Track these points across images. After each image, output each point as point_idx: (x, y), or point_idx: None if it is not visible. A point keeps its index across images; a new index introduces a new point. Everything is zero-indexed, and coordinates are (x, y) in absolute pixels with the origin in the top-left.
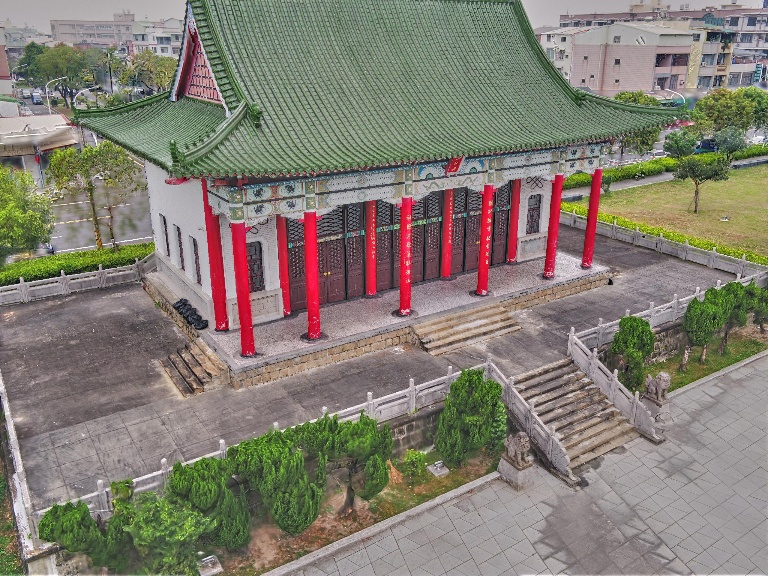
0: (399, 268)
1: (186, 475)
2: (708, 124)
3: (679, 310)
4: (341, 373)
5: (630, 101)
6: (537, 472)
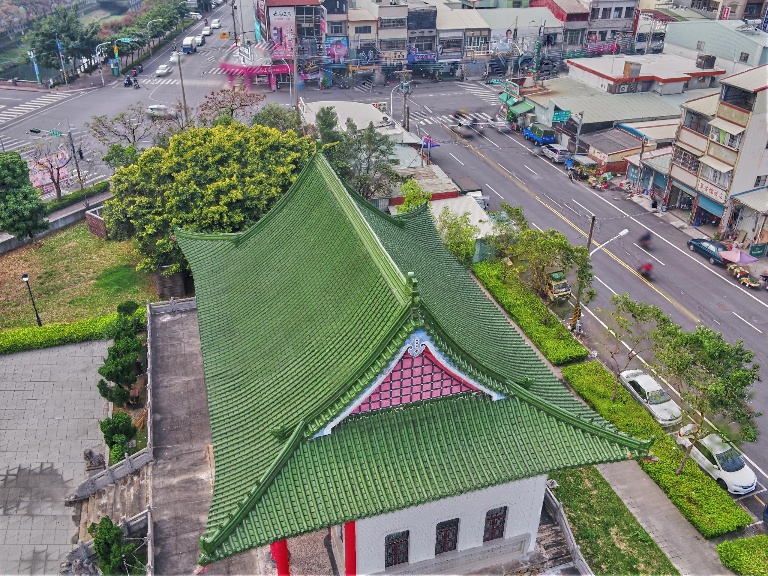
0: None
1: None
2: None
3: None
4: None
5: None
6: None
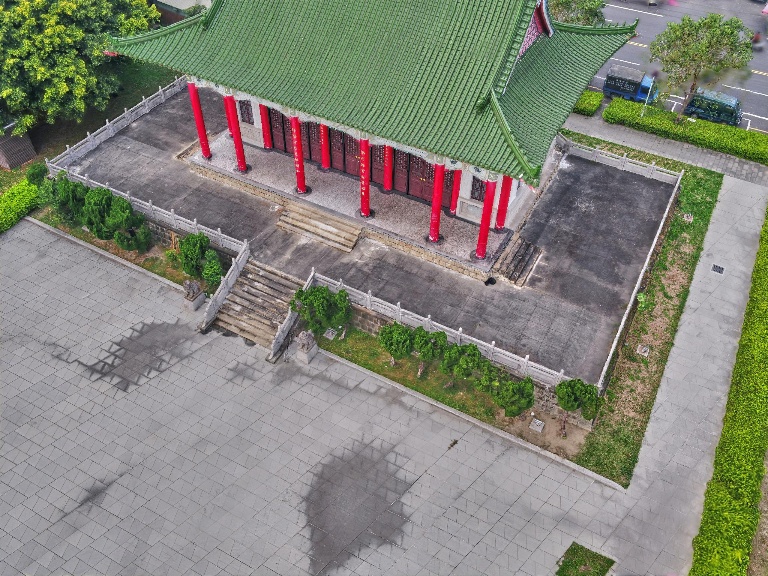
0: (351, 161)
1: None
2: None
3: (433, 330)
4: (230, 197)
5: None
6: None
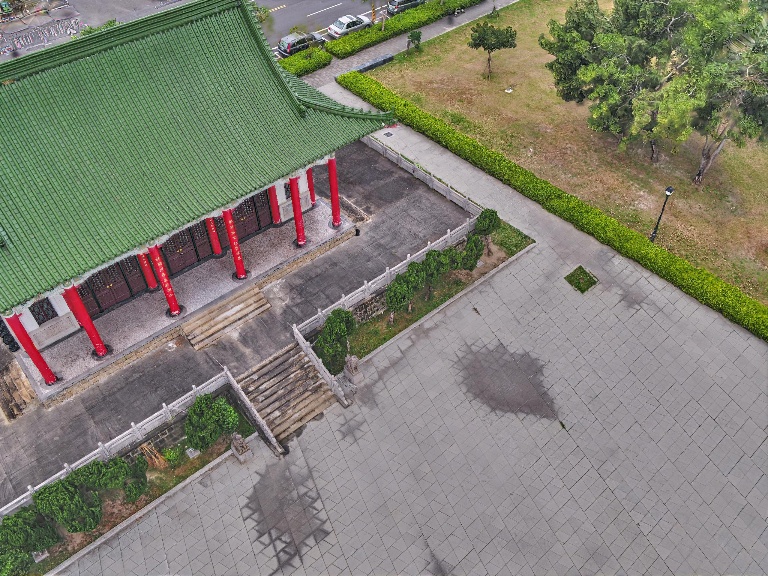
0: (174, 260)
1: (3, 532)
2: None
3: (393, 275)
4: (125, 380)
5: None
6: (259, 445)
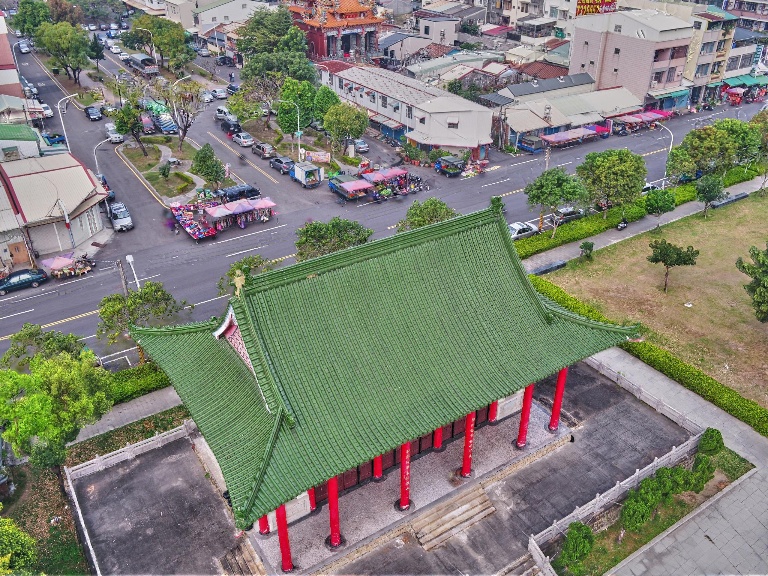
0: (400, 450)
1: None
2: (691, 167)
3: (621, 490)
4: (356, 575)
5: (616, 163)
6: None
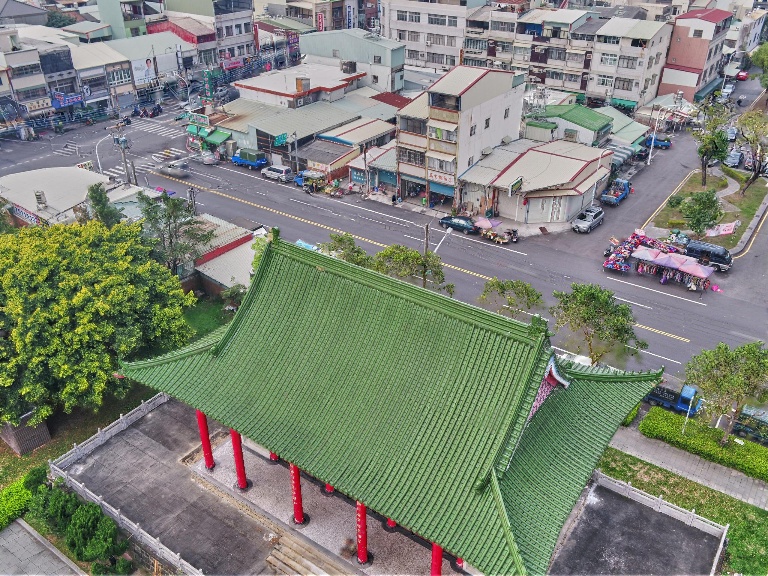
0: None
1: None
2: None
3: None
4: (225, 517)
5: None
6: None
